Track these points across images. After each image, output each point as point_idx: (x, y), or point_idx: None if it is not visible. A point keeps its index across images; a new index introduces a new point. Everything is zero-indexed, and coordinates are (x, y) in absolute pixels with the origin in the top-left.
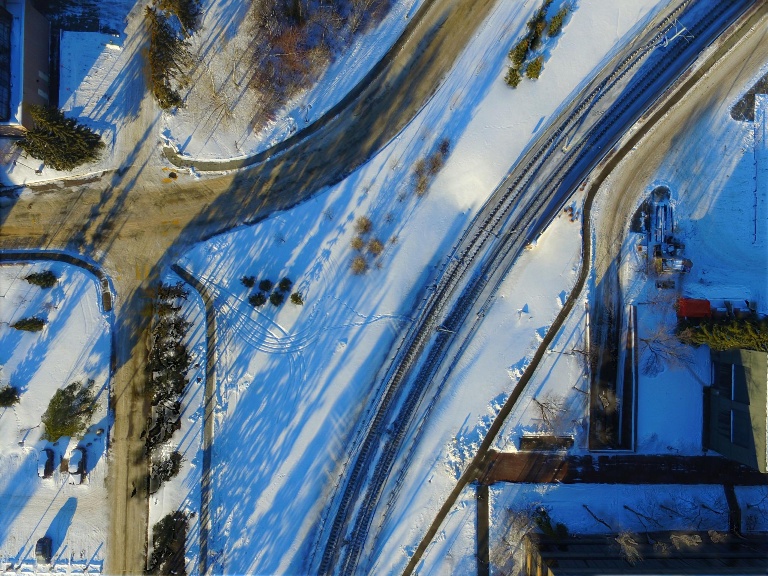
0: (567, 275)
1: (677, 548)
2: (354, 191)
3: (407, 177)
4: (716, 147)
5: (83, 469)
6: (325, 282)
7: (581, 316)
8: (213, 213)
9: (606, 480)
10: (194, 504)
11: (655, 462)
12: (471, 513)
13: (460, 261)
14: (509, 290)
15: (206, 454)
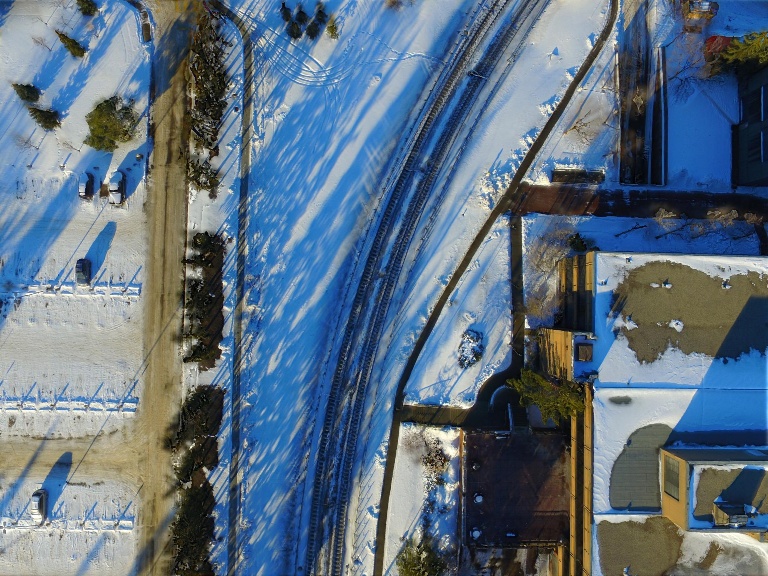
0: (596, 18)
1: (714, 228)
2: None
3: None
4: None
5: (123, 192)
6: (360, 18)
7: (610, 57)
8: None
9: (637, 214)
10: (232, 229)
11: (685, 198)
12: (505, 241)
13: (490, 9)
14: (539, 37)
15: (243, 182)
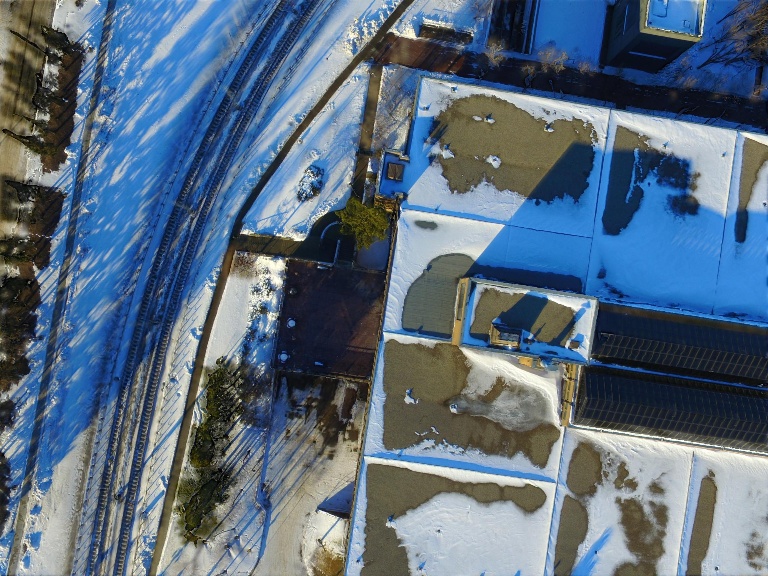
0: None
1: (545, 71)
2: None
3: None
4: None
5: None
6: None
7: None
8: None
9: (500, 79)
10: (94, 39)
11: (551, 71)
12: (362, 87)
13: None
14: None
15: None
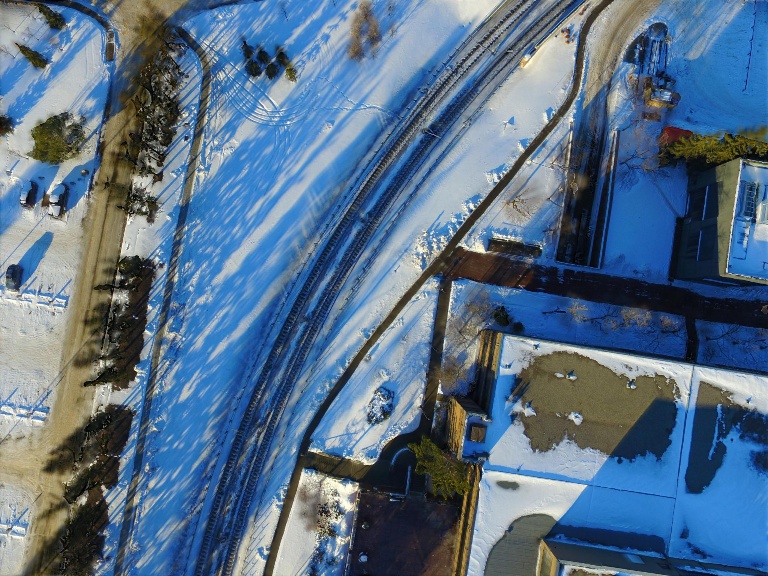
0: (556, 93)
1: (627, 326)
2: None
3: None
4: None
5: (63, 204)
6: (320, 64)
7: (565, 134)
8: None
9: (569, 293)
10: (164, 255)
11: (620, 284)
12: (431, 303)
13: (454, 70)
14: (498, 104)
15: (183, 210)
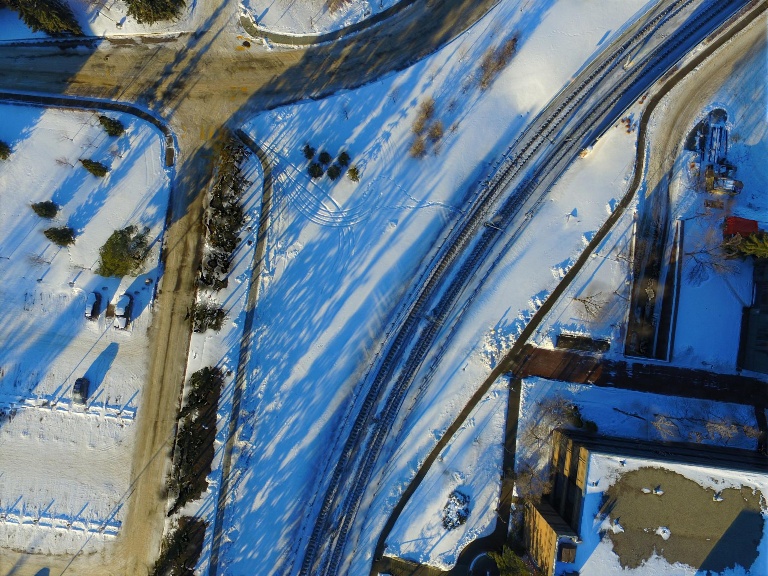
0: (618, 184)
1: (712, 438)
2: (420, 78)
3: (472, 71)
4: None
5: (128, 315)
6: (382, 162)
7: (628, 225)
8: (281, 84)
9: (638, 387)
10: (232, 363)
11: (688, 376)
12: (502, 403)
13: (514, 161)
14: (559, 194)
15: (249, 316)
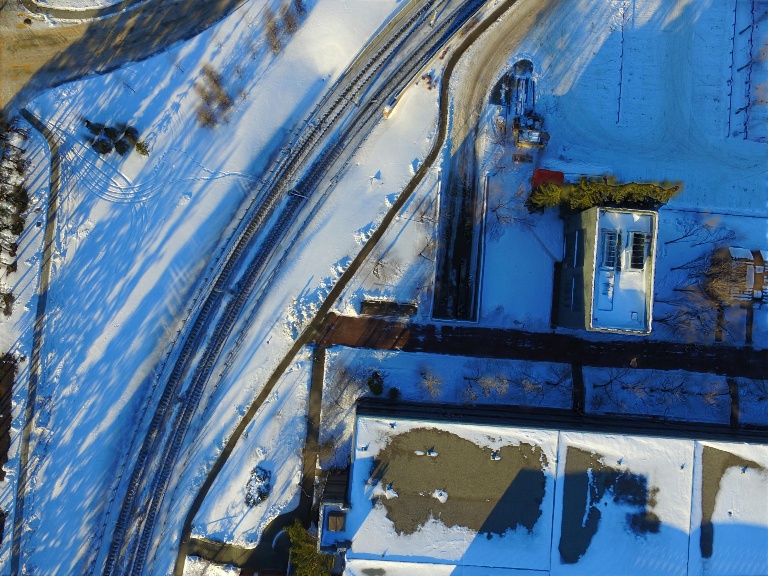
0: (422, 143)
1: (487, 395)
2: (208, 46)
3: (263, 35)
4: (583, 23)
5: None
6: (173, 134)
7: (433, 184)
8: (65, 60)
9: (448, 351)
10: (25, 348)
11: (501, 336)
12: (305, 374)
13: (317, 127)
14: (364, 158)
15: (41, 299)
